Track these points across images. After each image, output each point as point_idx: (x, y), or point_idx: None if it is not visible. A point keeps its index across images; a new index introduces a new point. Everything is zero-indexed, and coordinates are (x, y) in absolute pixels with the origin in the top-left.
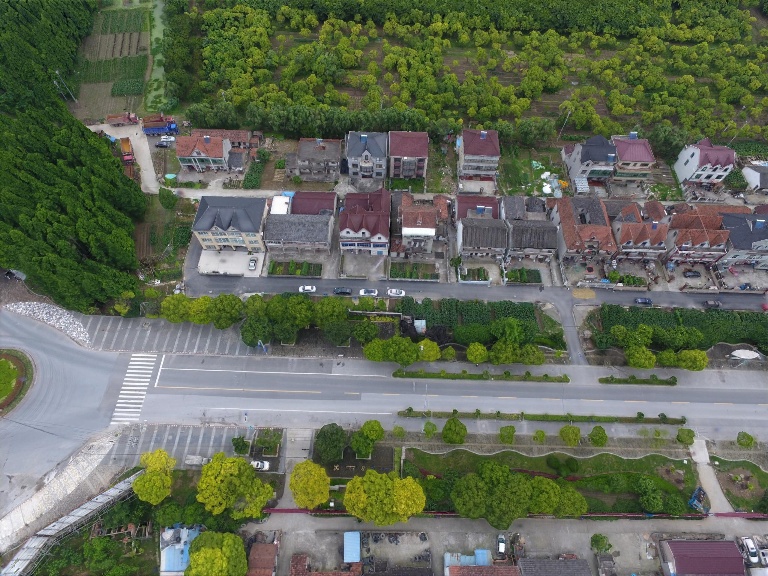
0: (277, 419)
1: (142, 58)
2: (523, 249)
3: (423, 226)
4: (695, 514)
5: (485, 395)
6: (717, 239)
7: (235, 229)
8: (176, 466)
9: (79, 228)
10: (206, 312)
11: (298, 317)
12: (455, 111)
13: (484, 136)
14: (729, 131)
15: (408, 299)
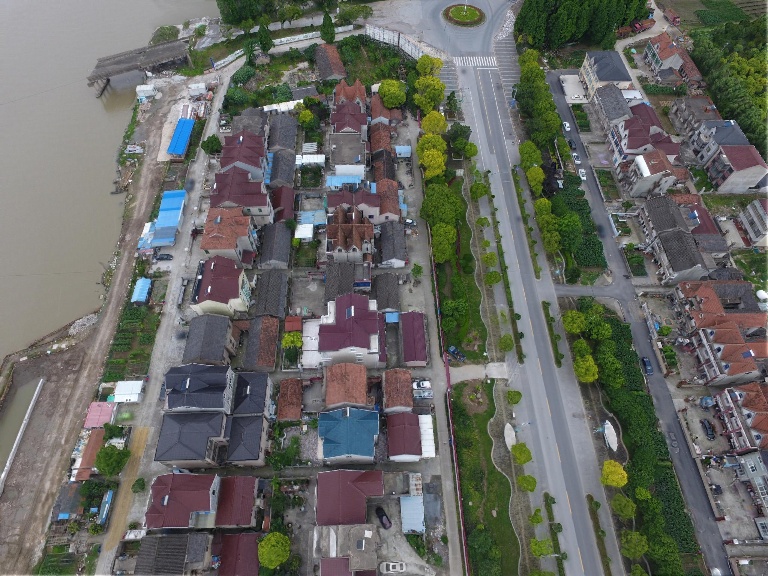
0: (470, 118)
1: (746, 16)
2: None
3: (650, 166)
4: None
5: (511, 222)
6: (765, 431)
7: (597, 68)
8: None
9: (566, 4)
10: None
11: (539, 105)
12: None
13: None
14: None
15: (579, 178)
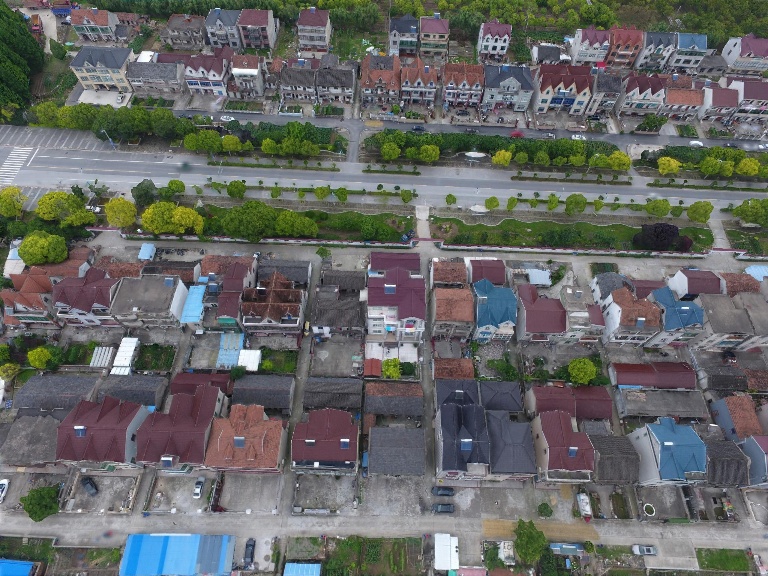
0: (114, 186)
1: None
2: (329, 89)
3: (248, 67)
4: (401, 242)
5: (273, 177)
6: (475, 81)
7: (102, 65)
8: (33, 209)
9: None
10: (70, 117)
11: (136, 118)
12: (308, 3)
13: (313, 11)
14: (527, 21)
15: (234, 121)
